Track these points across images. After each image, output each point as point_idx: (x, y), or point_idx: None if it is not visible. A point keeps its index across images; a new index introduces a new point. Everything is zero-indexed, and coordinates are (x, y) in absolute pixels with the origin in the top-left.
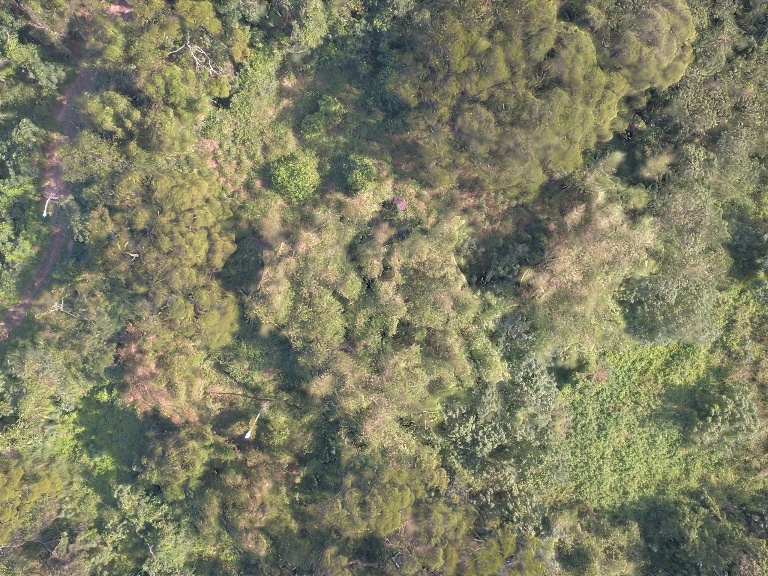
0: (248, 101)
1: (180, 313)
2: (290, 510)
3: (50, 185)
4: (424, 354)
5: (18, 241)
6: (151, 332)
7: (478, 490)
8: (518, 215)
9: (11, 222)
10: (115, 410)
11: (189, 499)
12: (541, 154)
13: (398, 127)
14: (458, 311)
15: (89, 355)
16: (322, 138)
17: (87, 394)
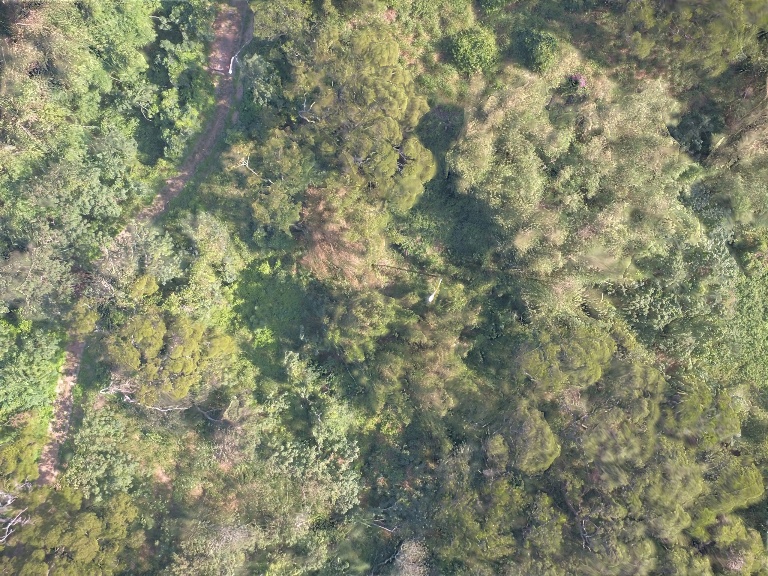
0: None
1: (388, 160)
2: (469, 376)
3: (216, 56)
4: (630, 209)
5: (187, 107)
6: (340, 190)
7: (652, 364)
8: (693, 97)
9: (176, 90)
10: (277, 282)
11: (370, 361)
12: (750, 17)
13: (578, 6)
14: (663, 169)
15: (279, 209)
16: (501, 15)
17: (247, 267)
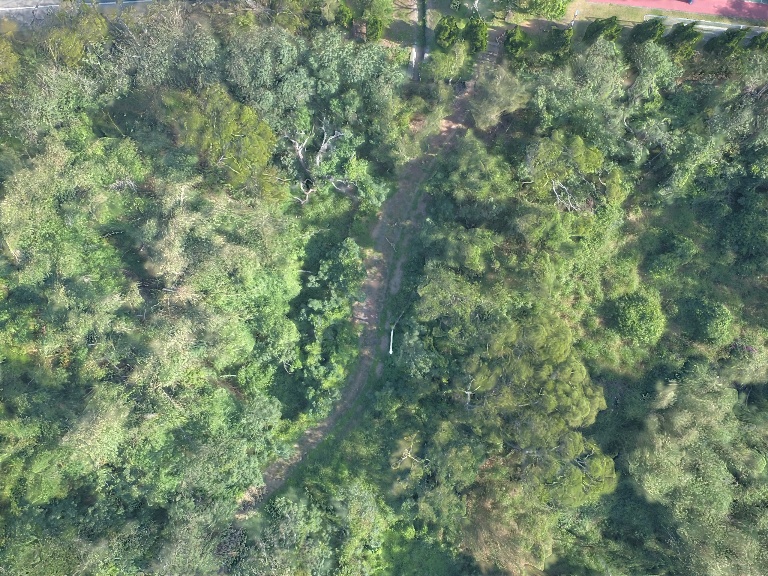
0: (600, 238)
1: None
2: None
3: (360, 304)
4: None
5: (334, 366)
6: (510, 487)
7: None
8: None
9: (319, 342)
10: (423, 548)
11: None
12: None
13: (751, 272)
14: None
15: None
16: (668, 278)
17: (390, 528)
